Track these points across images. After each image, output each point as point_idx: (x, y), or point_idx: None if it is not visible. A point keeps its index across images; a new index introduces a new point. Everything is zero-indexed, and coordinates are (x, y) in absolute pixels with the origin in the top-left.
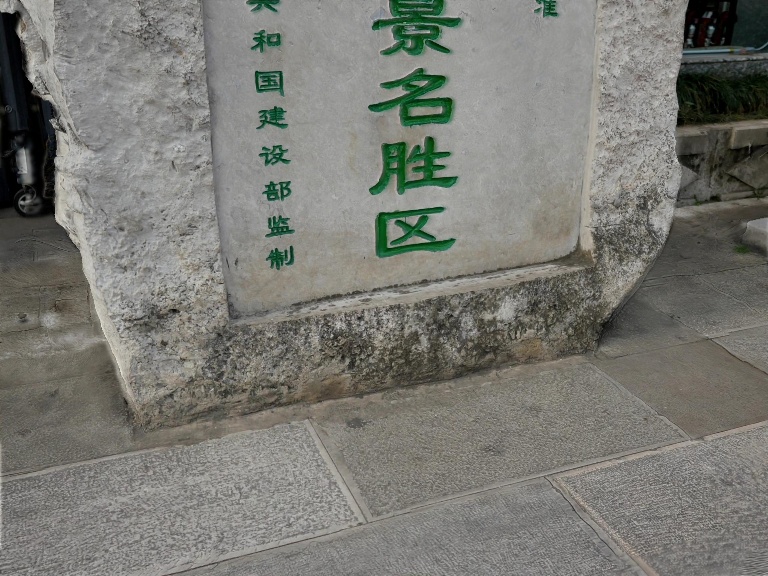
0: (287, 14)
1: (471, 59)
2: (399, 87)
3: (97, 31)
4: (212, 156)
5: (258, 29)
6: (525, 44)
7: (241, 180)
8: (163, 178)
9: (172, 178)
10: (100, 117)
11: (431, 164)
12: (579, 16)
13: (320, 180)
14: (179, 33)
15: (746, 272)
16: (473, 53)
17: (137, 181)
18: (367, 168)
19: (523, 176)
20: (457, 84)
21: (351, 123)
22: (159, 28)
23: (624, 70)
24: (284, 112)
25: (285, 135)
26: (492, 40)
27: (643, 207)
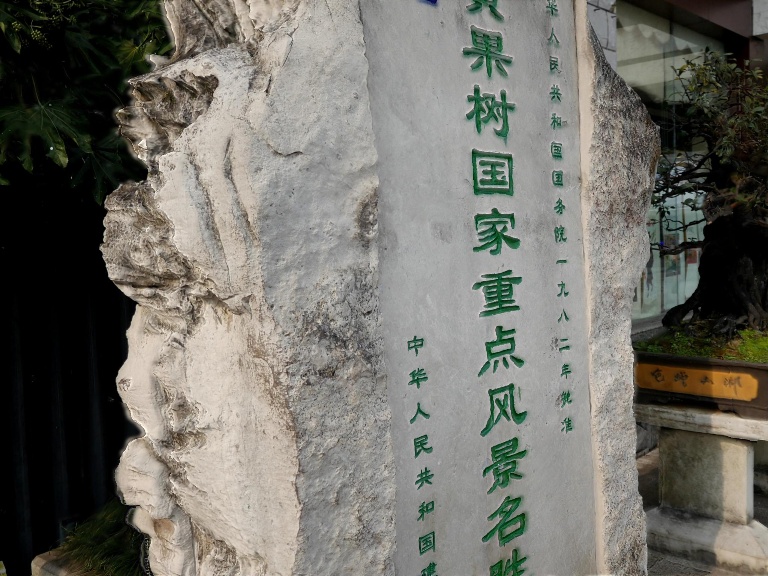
0: (438, 484)
1: (533, 479)
2: (497, 516)
3: (325, 544)
4: None
5: (421, 502)
6: (559, 457)
7: None
8: None
9: None
10: None
11: (516, 571)
12: (582, 426)
13: None
14: (381, 527)
15: (654, 573)
16: (534, 474)
17: None
18: None
19: (565, 559)
20: (527, 501)
21: (473, 558)
22: (369, 527)
23: (610, 458)
24: (435, 566)
25: None
26: (543, 460)
27: (633, 558)
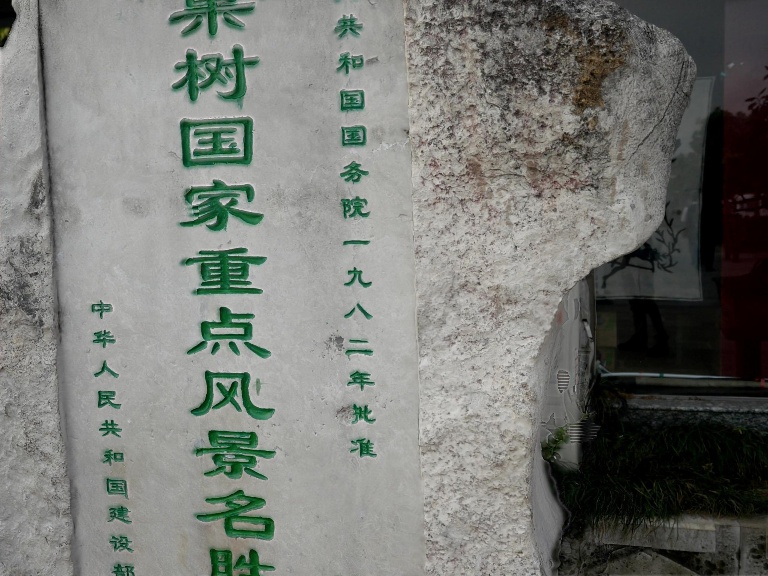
0: (128, 440)
1: (289, 488)
2: (223, 504)
3: (6, 443)
4: (74, 538)
5: (108, 449)
6: (344, 480)
7: (96, 559)
8: (40, 548)
9: (46, 549)
10: (4, 499)
11: (258, 574)
12: (402, 459)
13: (158, 570)
14: (49, 449)
15: None
16: (291, 483)
17: (25, 547)
18: (198, 568)
19: None
20: (278, 508)
21: (183, 528)
22: (37, 445)
23: (456, 519)
24: (129, 512)
25: (130, 530)
26: (308, 473)
27: None
